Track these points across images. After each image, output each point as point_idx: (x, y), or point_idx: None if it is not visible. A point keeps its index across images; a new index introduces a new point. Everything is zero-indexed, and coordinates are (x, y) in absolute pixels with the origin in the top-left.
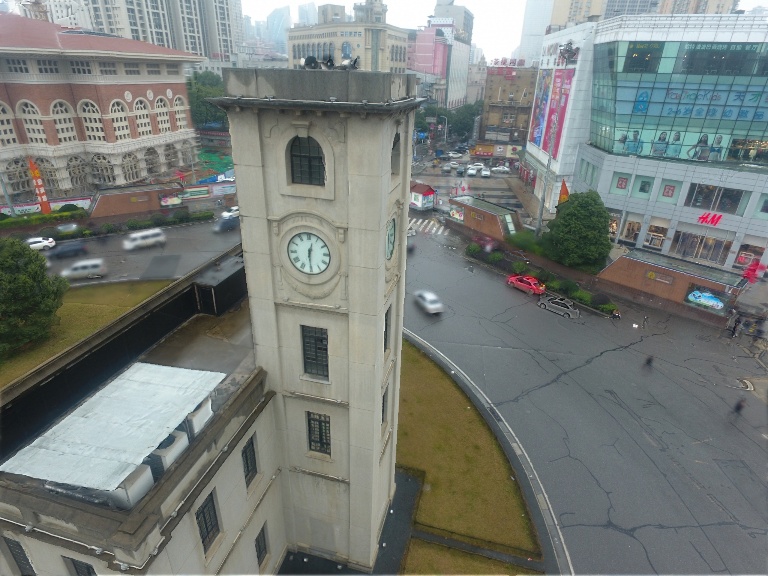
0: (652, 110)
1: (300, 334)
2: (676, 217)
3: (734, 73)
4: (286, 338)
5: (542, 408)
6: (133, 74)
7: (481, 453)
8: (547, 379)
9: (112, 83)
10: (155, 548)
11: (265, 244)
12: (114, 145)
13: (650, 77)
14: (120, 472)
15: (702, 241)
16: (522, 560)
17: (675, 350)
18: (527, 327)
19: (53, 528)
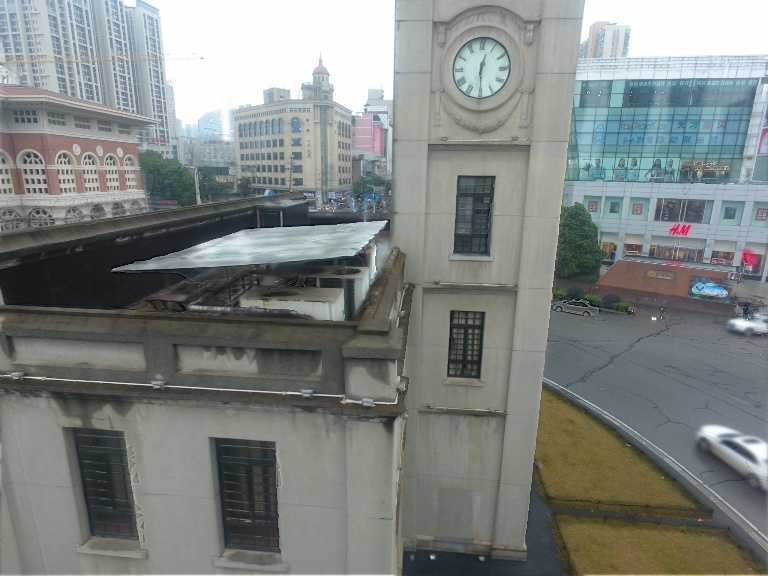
0: (609, 140)
1: (456, 191)
2: (649, 232)
3: (674, 105)
4: (436, 200)
5: (614, 385)
6: (83, 128)
7: (579, 426)
8: (602, 362)
9: (60, 134)
10: (399, 382)
11: (426, 58)
12: (58, 197)
13: (604, 111)
14: (341, 250)
15: (676, 252)
16: (693, 522)
17: (703, 333)
18: (554, 325)
19: (208, 375)
